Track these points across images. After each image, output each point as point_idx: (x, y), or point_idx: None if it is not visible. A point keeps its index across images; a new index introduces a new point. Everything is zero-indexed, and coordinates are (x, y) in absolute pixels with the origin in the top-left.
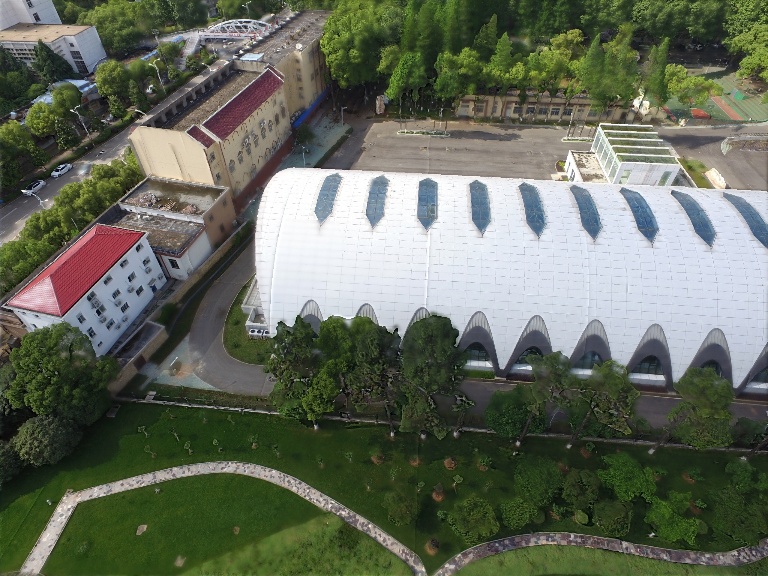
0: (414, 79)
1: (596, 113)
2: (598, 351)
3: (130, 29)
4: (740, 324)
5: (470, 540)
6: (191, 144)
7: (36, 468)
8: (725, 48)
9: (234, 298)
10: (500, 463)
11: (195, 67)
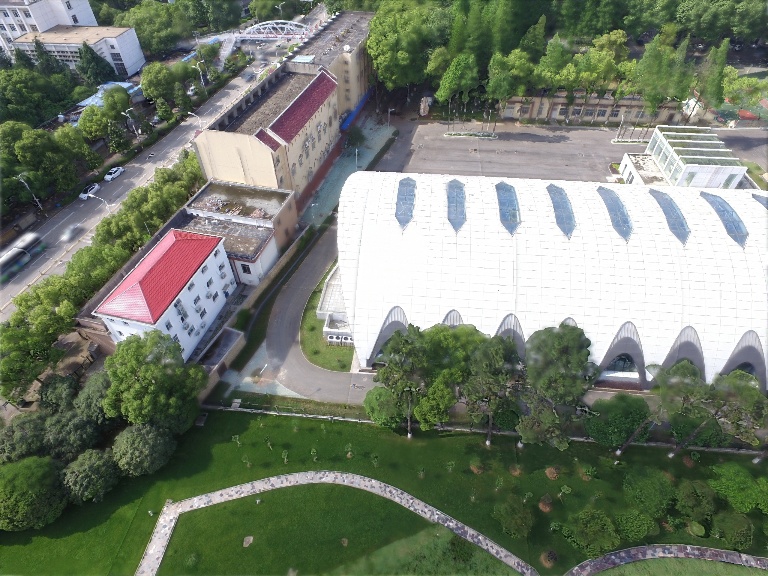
0: (466, 81)
1: (643, 114)
2: (691, 358)
3: (168, 31)
4: None
5: (592, 553)
6: (258, 148)
7: (132, 478)
8: (764, 48)
9: (305, 303)
10: (603, 473)
11: (233, 69)
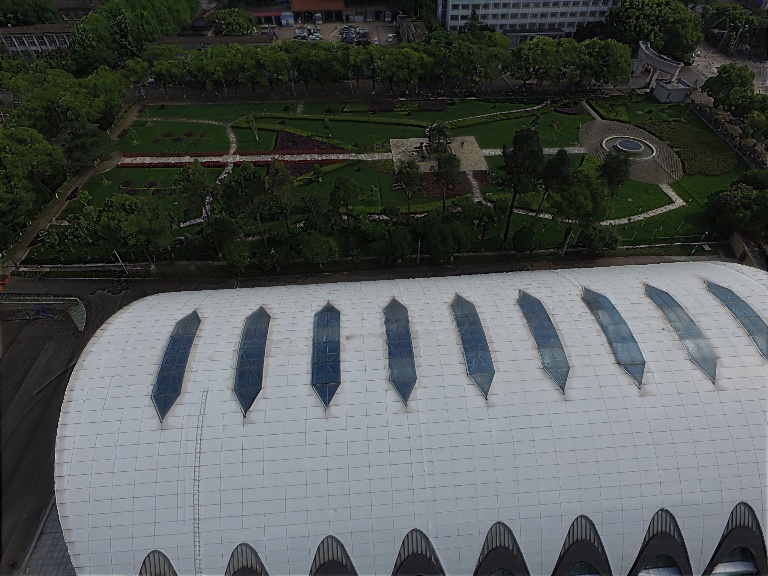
0: None
1: None
2: None
3: None
4: None
5: None
6: None
7: None
8: None
9: None
10: None
11: None
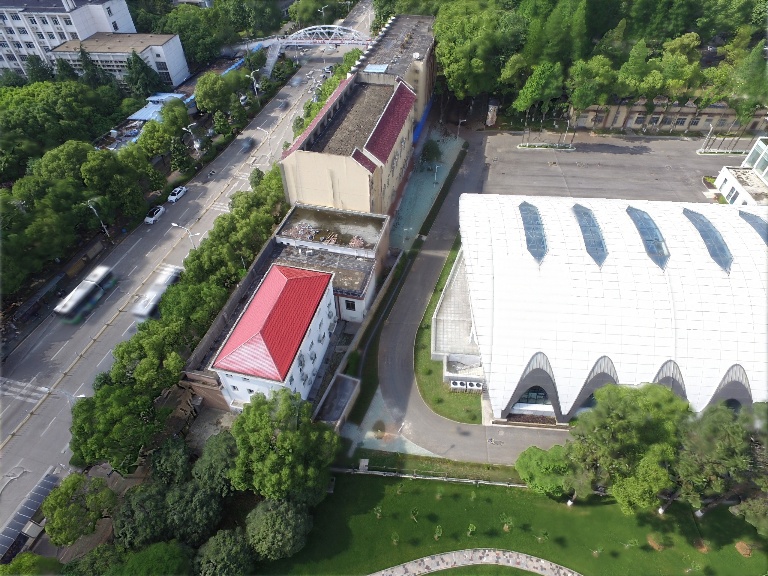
0: (550, 90)
1: (725, 123)
2: None
3: (213, 37)
4: None
5: None
6: (355, 170)
7: (265, 560)
8: None
9: (413, 342)
10: None
11: (282, 77)
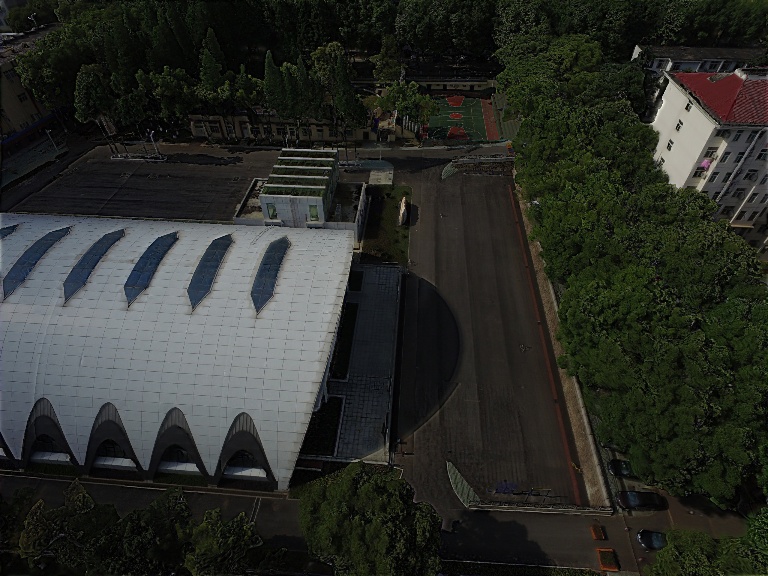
0: (94, 101)
1: (337, 133)
2: (50, 434)
3: None
4: (201, 403)
5: None
6: None
7: None
8: None
9: None
10: None
11: None
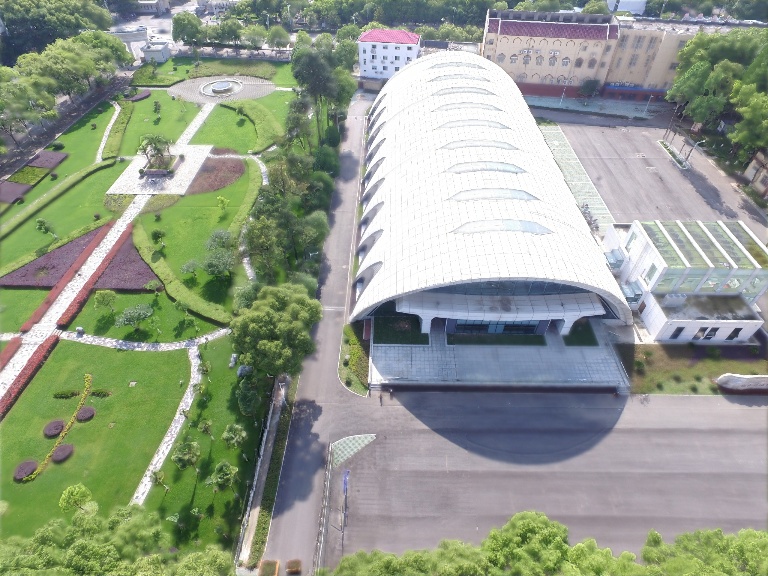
0: (686, 87)
1: None
2: None
3: None
4: None
5: None
6: None
7: None
8: None
9: None
10: None
11: None
